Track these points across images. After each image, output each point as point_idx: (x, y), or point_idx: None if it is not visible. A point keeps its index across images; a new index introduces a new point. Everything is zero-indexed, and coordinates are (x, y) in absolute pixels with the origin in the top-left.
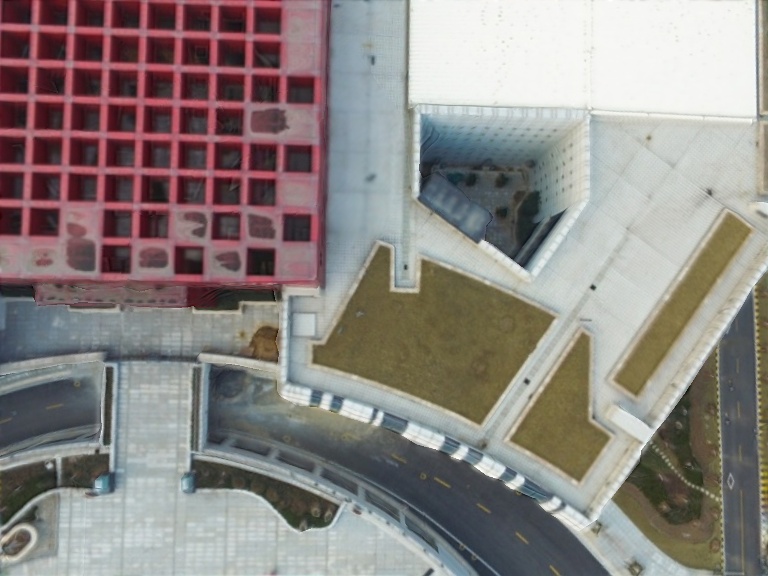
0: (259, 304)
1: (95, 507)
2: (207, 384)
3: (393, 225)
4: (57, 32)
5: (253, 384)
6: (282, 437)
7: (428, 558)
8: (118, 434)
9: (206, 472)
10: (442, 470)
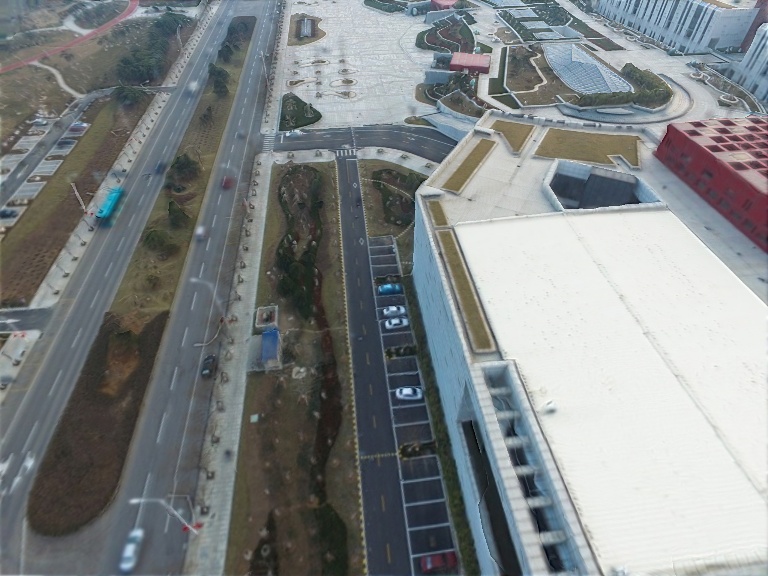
0: None
1: None
2: None
3: (637, 175)
4: None
5: None
6: None
7: None
8: None
9: None
10: None
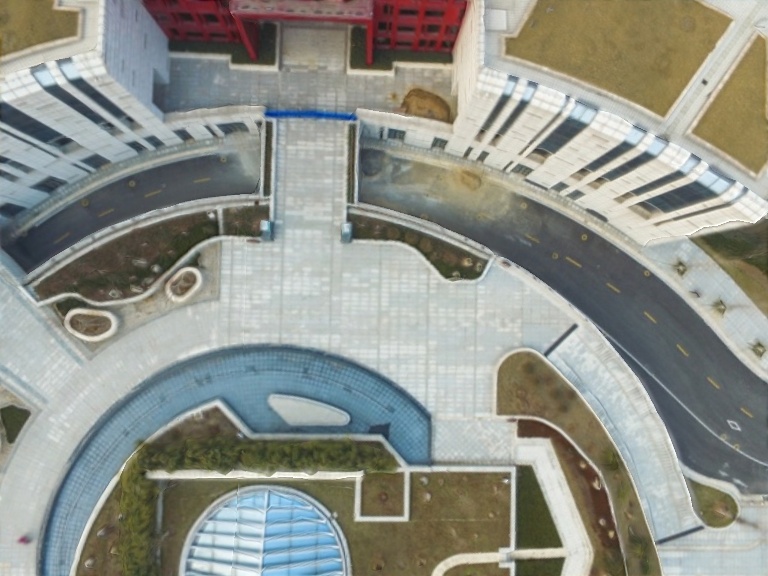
0: (410, 67)
1: (255, 256)
2: (358, 147)
3: None
4: None
5: (392, 164)
6: (419, 215)
7: (573, 312)
8: (277, 187)
9: (361, 224)
10: (573, 250)
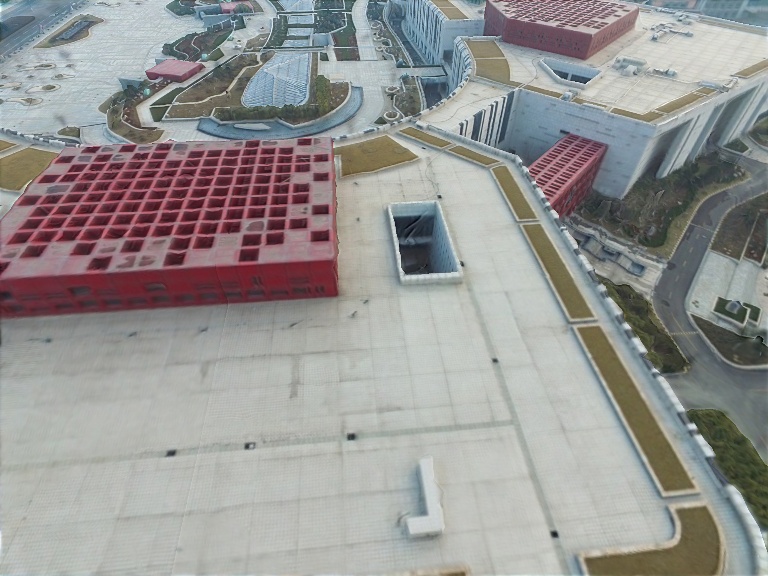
0: None
1: None
2: None
3: None
4: (170, 211)
5: None
6: None
7: None
8: None
9: None
10: None
